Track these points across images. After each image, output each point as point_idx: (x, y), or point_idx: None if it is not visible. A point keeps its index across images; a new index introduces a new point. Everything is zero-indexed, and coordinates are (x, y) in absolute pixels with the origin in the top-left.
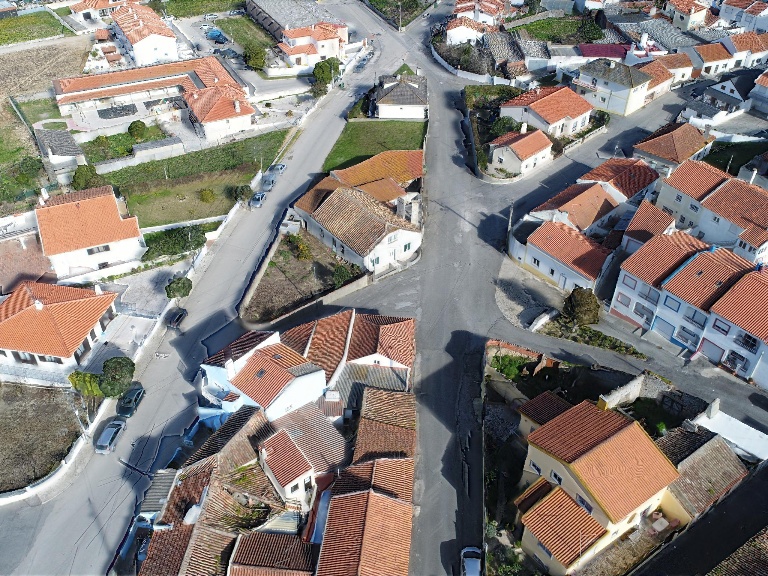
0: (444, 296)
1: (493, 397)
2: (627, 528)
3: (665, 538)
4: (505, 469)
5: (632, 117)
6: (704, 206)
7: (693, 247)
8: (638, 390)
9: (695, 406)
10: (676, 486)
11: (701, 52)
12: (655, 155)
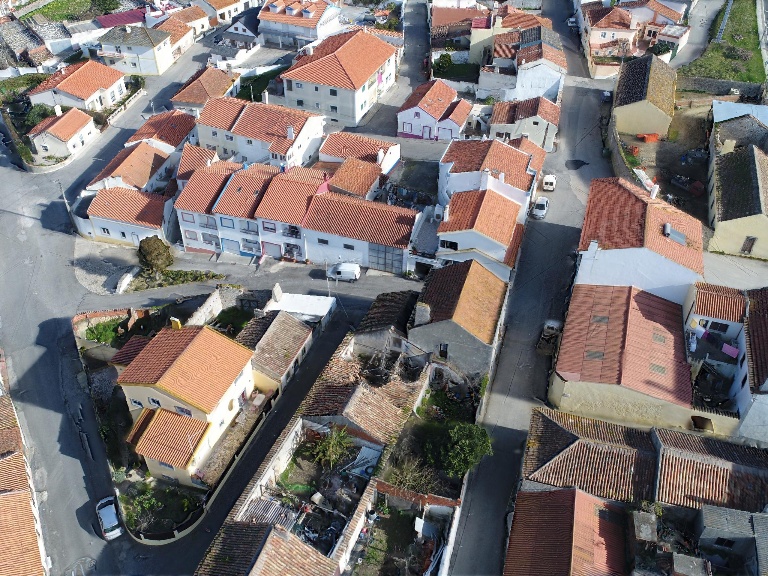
0: (21, 295)
1: (94, 365)
2: (233, 415)
3: (263, 408)
4: (121, 420)
5: (167, 74)
6: (235, 134)
7: (231, 170)
8: (220, 304)
9: (265, 297)
10: (258, 364)
11: (210, 2)
12: (192, 103)
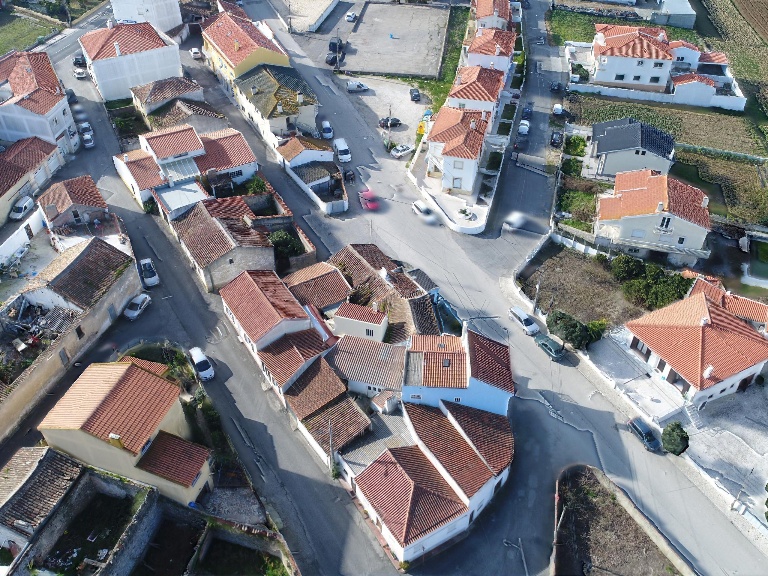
0: None
1: None
2: None
3: None
4: None
5: None
6: None
7: None
8: None
9: None
10: None
11: None
12: None
